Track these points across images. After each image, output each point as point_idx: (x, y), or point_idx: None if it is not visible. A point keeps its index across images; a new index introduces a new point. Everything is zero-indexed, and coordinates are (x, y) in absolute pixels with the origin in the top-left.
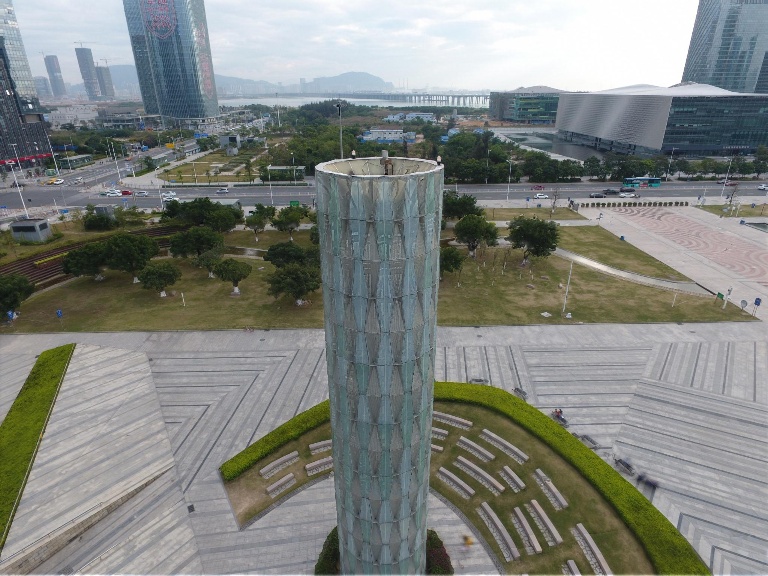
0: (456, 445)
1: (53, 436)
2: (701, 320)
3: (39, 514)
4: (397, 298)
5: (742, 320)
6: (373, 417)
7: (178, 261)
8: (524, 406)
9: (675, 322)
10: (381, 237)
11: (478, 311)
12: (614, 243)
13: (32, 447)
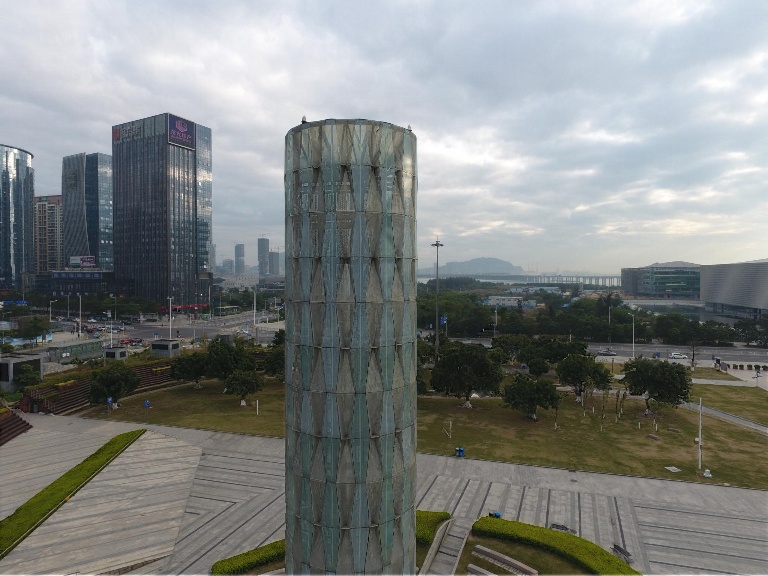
0: None
1: (78, 501)
2: None
3: (17, 569)
4: (345, 259)
5: None
6: (318, 426)
7: (270, 381)
8: (623, 567)
9: None
10: (328, 185)
11: (577, 455)
12: None
13: (53, 505)
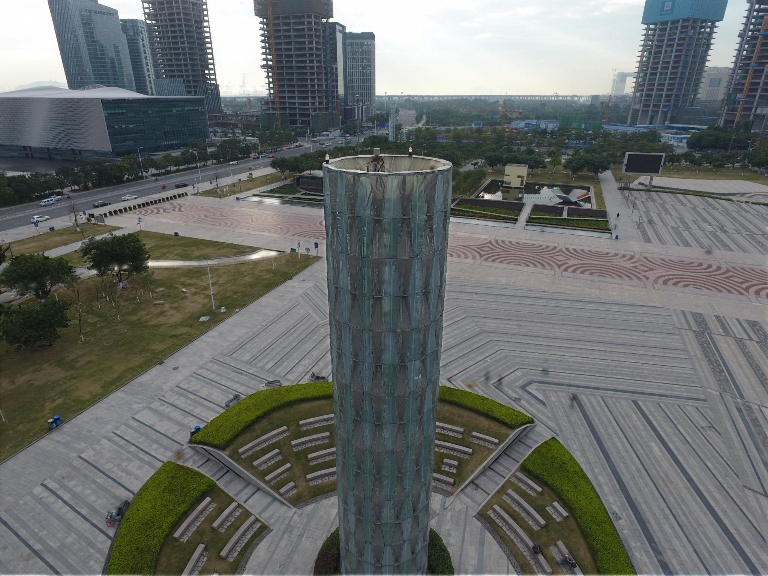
0: (295, 451)
1: None
2: (298, 271)
3: None
4: None
5: (315, 261)
6: None
7: None
8: (294, 388)
9: (288, 279)
10: None
11: (141, 349)
12: (175, 240)
13: None
